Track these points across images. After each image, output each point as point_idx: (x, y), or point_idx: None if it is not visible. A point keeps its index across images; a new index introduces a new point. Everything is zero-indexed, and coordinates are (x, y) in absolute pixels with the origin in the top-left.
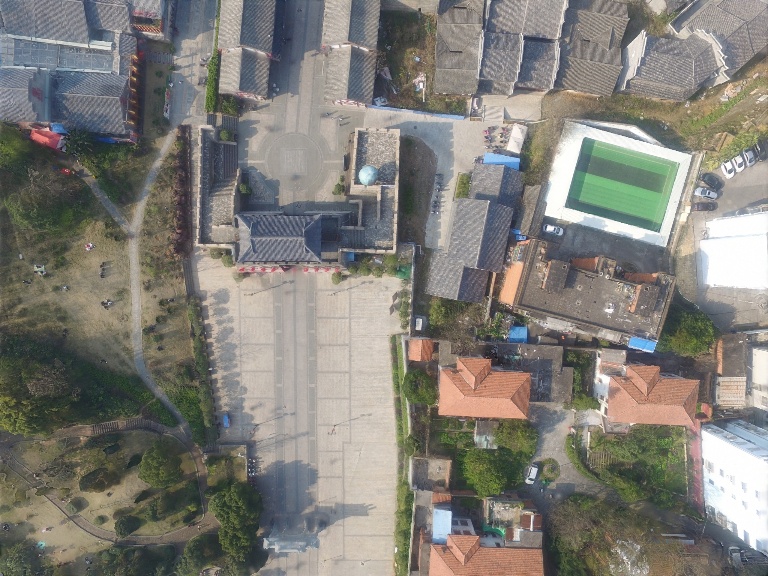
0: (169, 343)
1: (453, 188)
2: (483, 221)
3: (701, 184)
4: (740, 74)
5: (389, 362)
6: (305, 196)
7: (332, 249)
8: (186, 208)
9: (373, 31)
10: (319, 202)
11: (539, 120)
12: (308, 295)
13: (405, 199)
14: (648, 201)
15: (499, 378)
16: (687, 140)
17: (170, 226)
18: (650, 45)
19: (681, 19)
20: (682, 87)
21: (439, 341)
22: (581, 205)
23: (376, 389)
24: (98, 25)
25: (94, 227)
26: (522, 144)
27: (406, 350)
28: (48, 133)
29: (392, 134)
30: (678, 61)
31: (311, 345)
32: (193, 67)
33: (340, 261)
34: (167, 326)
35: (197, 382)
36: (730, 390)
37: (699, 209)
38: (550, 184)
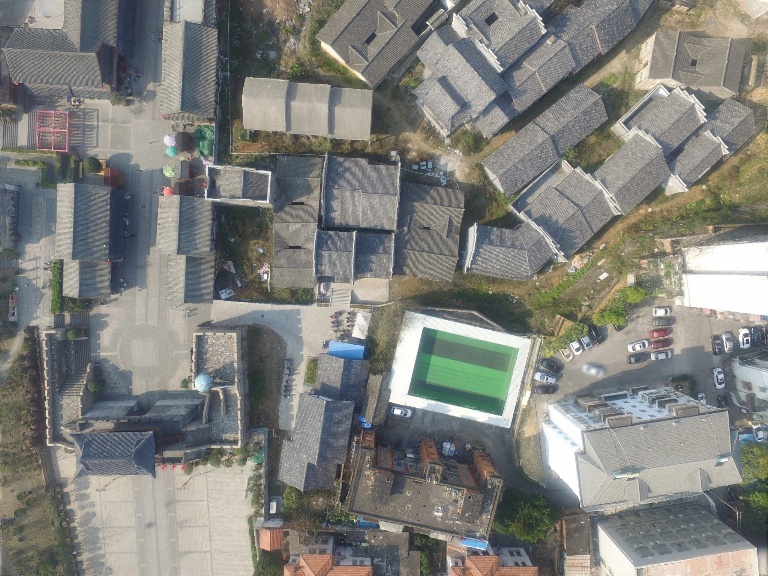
0: (30, 534)
1: (303, 372)
2: (321, 420)
3: (541, 367)
4: (586, 246)
5: (248, 541)
6: (158, 386)
7: (177, 448)
8: (41, 402)
9: (205, 239)
10: (172, 391)
11: (386, 302)
12: (166, 480)
13: (253, 388)
14: (494, 380)
15: (340, 574)
16: (534, 315)
17: (24, 422)
18: (483, 237)
19: (525, 195)
20: (519, 273)
21: (288, 530)
22: (428, 386)
23: (237, 567)
24: None
25: None
26: (367, 330)
27: (257, 538)
28: None
29: (231, 335)
30: (511, 252)
31: (172, 527)
32: (37, 270)
33: (183, 462)
34: (27, 518)
35: (61, 567)
36: (575, 567)
37: (539, 393)
38: (393, 372)
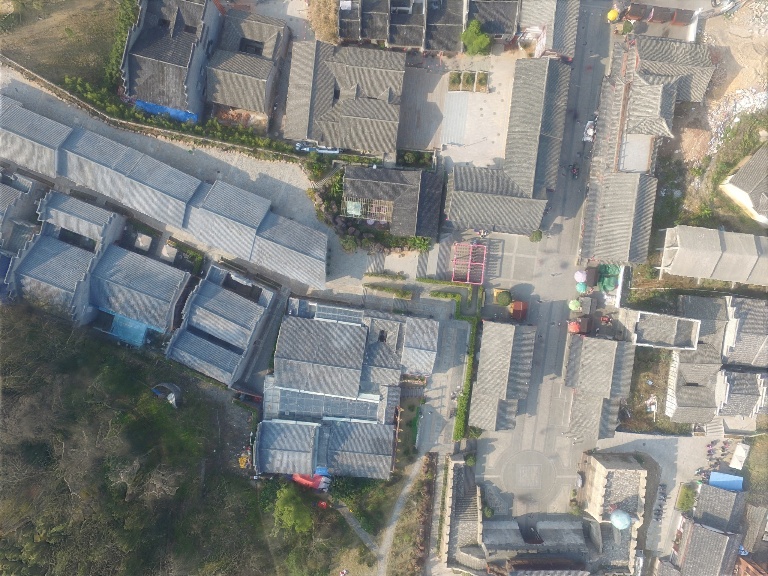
0: None
1: (675, 497)
2: (721, 554)
3: None
4: None
5: None
6: (538, 508)
7: None
8: None
9: (627, 381)
10: (551, 513)
11: (756, 433)
12: None
13: None
14: None
15: None
16: None
17: (413, 543)
18: None
19: None
20: None
21: None
22: None
23: None
24: (367, 380)
25: (348, 555)
26: (744, 461)
27: None
28: None
29: None
30: None
31: None
32: (443, 399)
33: None
34: None
35: None
36: None
37: None
38: None
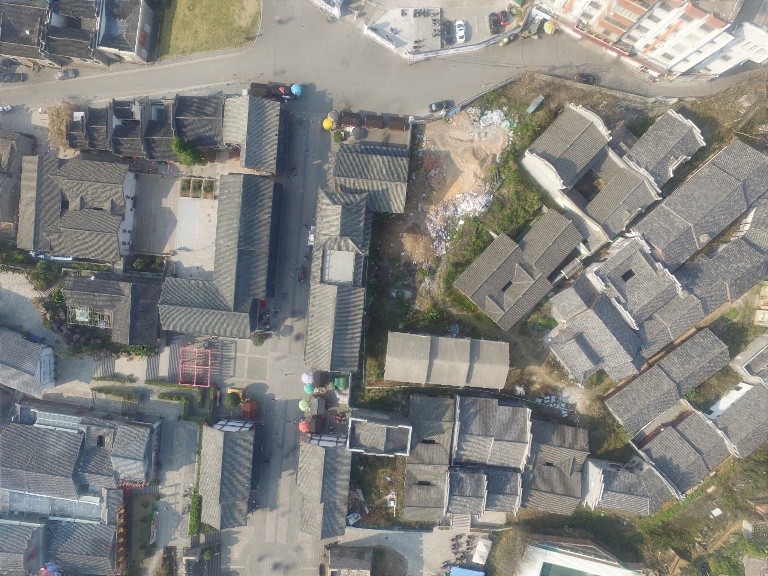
0: None
1: None
2: None
3: None
4: None
5: None
6: None
7: None
8: None
9: (344, 484)
10: None
11: (504, 526)
12: None
13: None
14: None
15: None
16: (644, 540)
17: None
18: (608, 483)
19: None
20: (638, 513)
21: None
22: None
23: None
24: (86, 483)
25: None
26: (487, 556)
27: None
28: (43, 571)
29: None
30: (634, 498)
31: None
32: (177, 496)
33: None
34: None
35: None
36: None
37: None
38: None
